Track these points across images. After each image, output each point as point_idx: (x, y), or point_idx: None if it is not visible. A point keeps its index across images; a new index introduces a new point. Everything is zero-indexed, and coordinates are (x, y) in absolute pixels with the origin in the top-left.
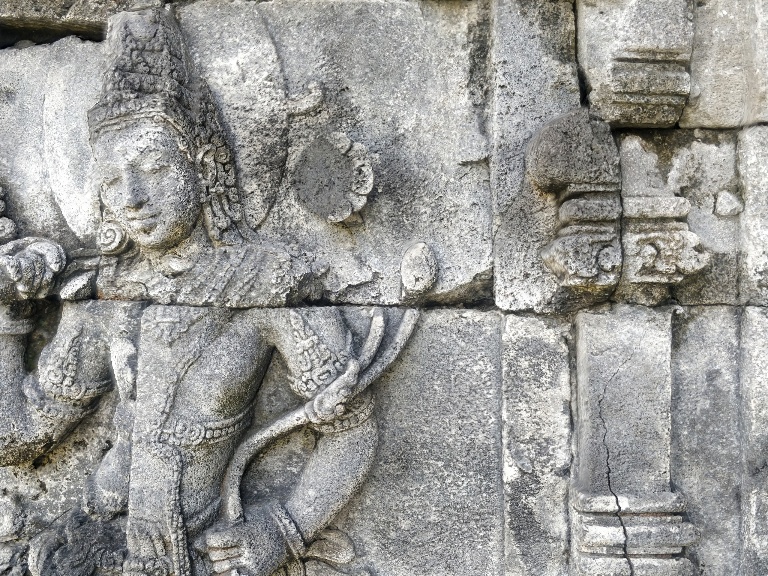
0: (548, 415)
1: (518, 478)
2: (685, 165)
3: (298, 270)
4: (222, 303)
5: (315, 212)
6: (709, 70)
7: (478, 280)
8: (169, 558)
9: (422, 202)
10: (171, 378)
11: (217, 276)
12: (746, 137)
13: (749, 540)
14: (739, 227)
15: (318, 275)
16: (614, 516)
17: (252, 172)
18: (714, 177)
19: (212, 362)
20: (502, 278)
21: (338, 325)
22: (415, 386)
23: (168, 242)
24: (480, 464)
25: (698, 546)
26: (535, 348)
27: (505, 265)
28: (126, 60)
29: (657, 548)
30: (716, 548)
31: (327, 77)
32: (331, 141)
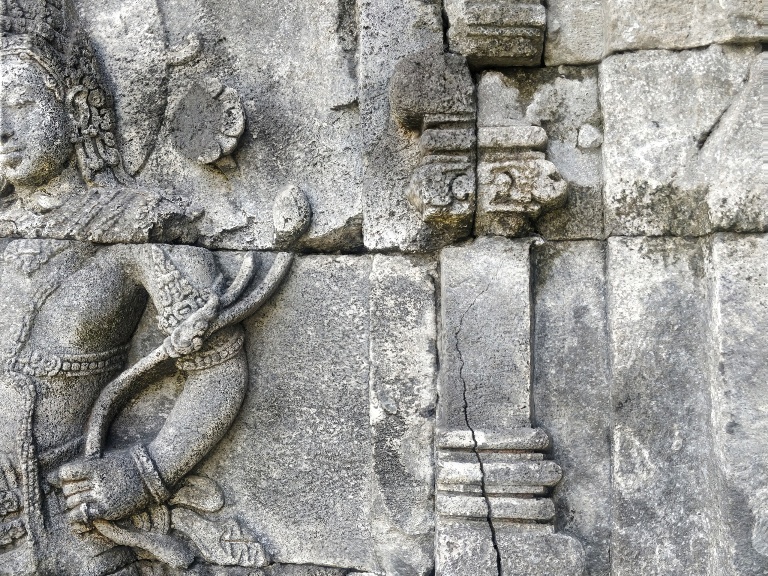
0: (413, 354)
1: (383, 420)
2: (547, 99)
3: (165, 209)
4: (85, 237)
5: (190, 157)
6: (569, 6)
7: (352, 225)
8: (20, 491)
9: (296, 147)
10: (27, 307)
11: (82, 212)
12: (602, 66)
13: (614, 479)
14: (602, 159)
15: (191, 219)
16: (471, 452)
17: (132, 120)
18: (577, 111)
19: (70, 293)
20: (368, 217)
21: (205, 265)
22: (289, 332)
23: (35, 178)
24: (352, 410)
25: (568, 491)
26: (401, 286)
27: (371, 204)
28: (1, 5)
29: (517, 487)
30: (587, 493)
31: (206, 28)
32: (203, 85)
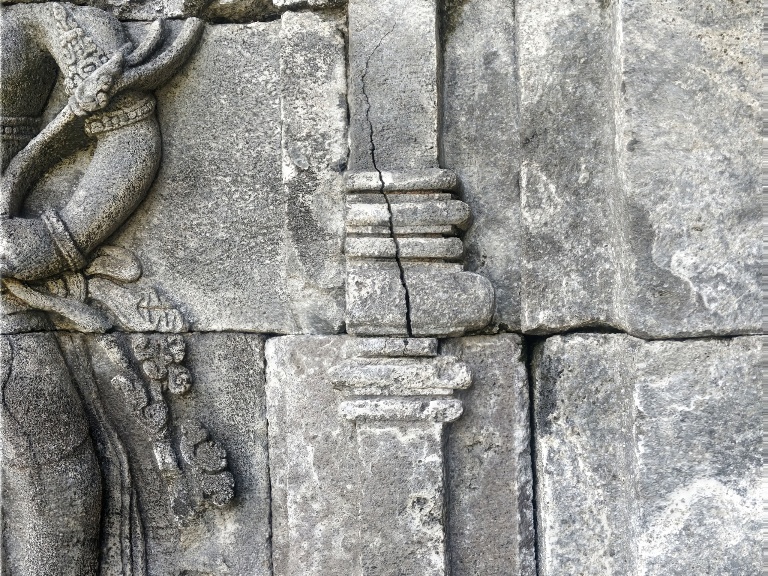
0: (324, 110)
1: (295, 176)
2: None
3: None
4: None
5: None
6: None
7: None
8: None
9: None
10: None
11: None
12: None
13: (521, 215)
14: None
15: None
16: (379, 194)
17: None
18: None
19: None
20: None
21: (112, 28)
22: (202, 101)
23: None
24: (267, 176)
25: (479, 236)
26: (310, 42)
27: None
28: None
29: (425, 226)
30: (498, 238)
31: None
32: None
